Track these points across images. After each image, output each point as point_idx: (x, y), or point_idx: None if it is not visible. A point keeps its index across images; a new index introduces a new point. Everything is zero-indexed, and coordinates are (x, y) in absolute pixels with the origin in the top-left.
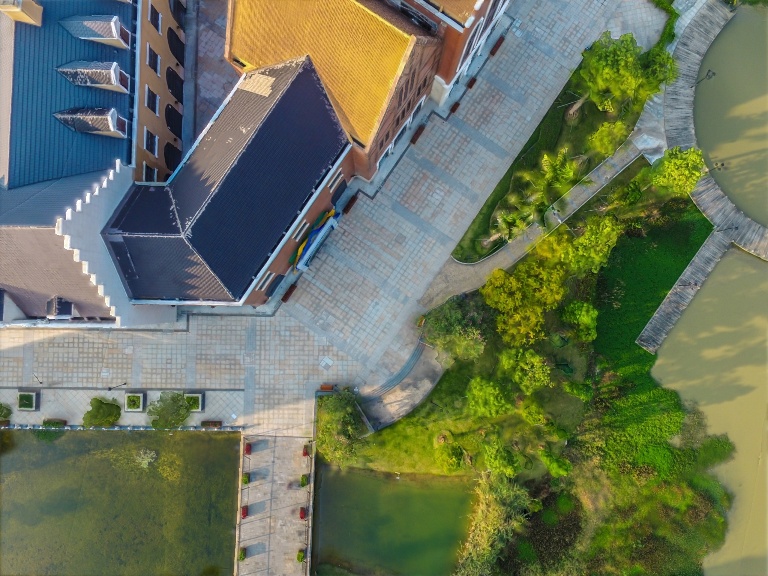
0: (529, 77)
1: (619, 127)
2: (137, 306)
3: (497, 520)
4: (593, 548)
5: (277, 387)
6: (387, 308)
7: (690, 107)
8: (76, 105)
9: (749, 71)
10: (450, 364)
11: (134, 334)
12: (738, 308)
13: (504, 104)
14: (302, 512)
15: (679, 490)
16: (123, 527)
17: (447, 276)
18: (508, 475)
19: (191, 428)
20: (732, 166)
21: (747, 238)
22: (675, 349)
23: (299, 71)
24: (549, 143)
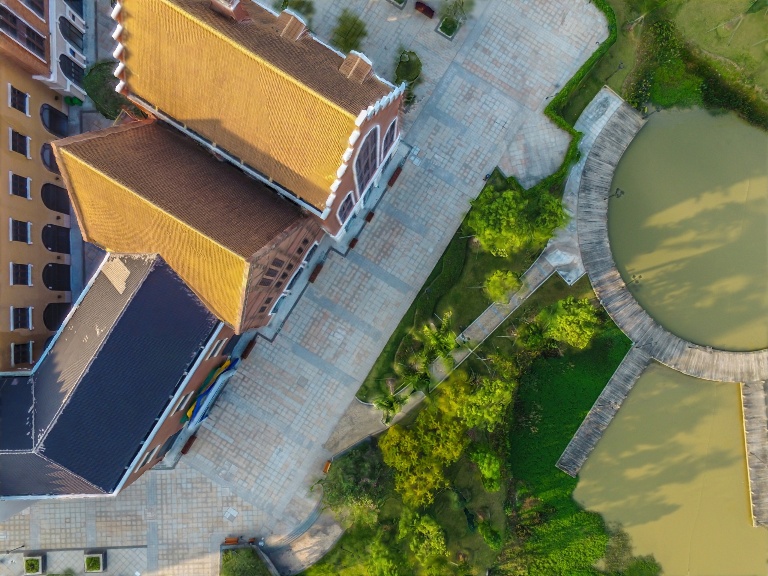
0: (430, 207)
1: (510, 280)
2: None
3: None
4: None
5: (181, 541)
6: (291, 454)
7: (604, 220)
8: None
9: (665, 176)
10: (348, 526)
11: None
12: (661, 424)
13: (405, 236)
14: None
15: None
16: None
17: (352, 418)
18: None
19: None
20: (650, 278)
21: (667, 353)
22: (597, 470)
23: (150, 270)
24: (453, 275)
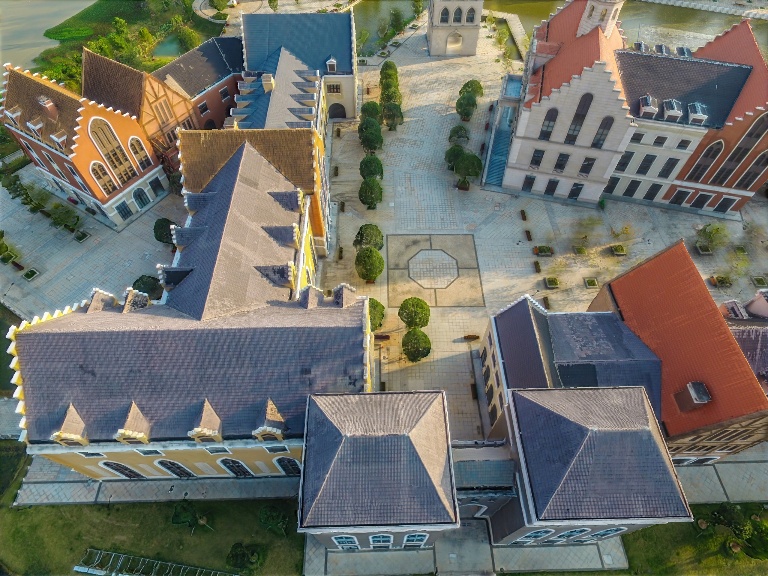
0: None
1: None
2: None
3: None
4: None
5: None
6: None
7: None
8: None
9: None
10: None
11: None
12: None
13: None
14: None
15: (56, 61)
16: None
17: None
18: None
19: None
20: None
21: None
22: None
23: None
24: None
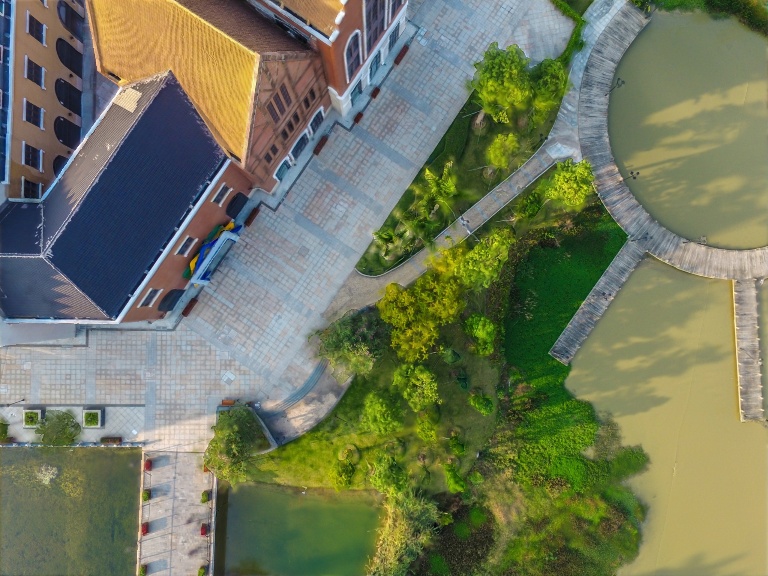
0: (434, 86)
1: (510, 139)
2: (15, 325)
3: (404, 534)
4: (506, 561)
5: (178, 402)
6: (290, 322)
7: (604, 115)
8: None
9: (666, 78)
10: (344, 380)
11: (32, 350)
12: (653, 318)
13: (409, 114)
14: (203, 528)
15: (592, 502)
16: (25, 544)
17: (351, 289)
18: (391, 494)
19: (90, 444)
20: (648, 175)
21: (662, 247)
22: (589, 360)
23: (162, 87)
24: (455, 153)
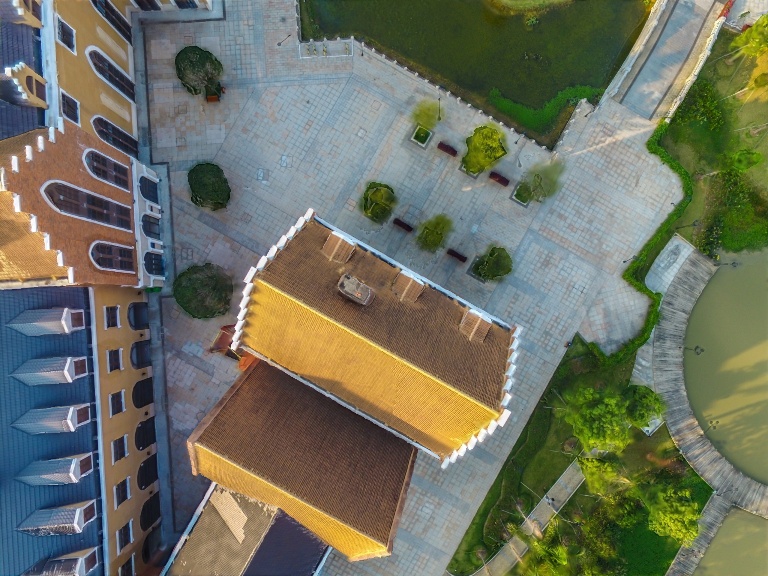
0: None
1: (610, 475)
2: None
3: None
4: None
5: None
6: None
7: (680, 368)
8: (41, 557)
9: (737, 318)
10: None
11: None
12: (744, 570)
13: None
14: None
15: None
16: None
17: None
18: None
19: None
20: (727, 423)
21: (748, 499)
22: None
23: (271, 524)
24: (538, 443)
